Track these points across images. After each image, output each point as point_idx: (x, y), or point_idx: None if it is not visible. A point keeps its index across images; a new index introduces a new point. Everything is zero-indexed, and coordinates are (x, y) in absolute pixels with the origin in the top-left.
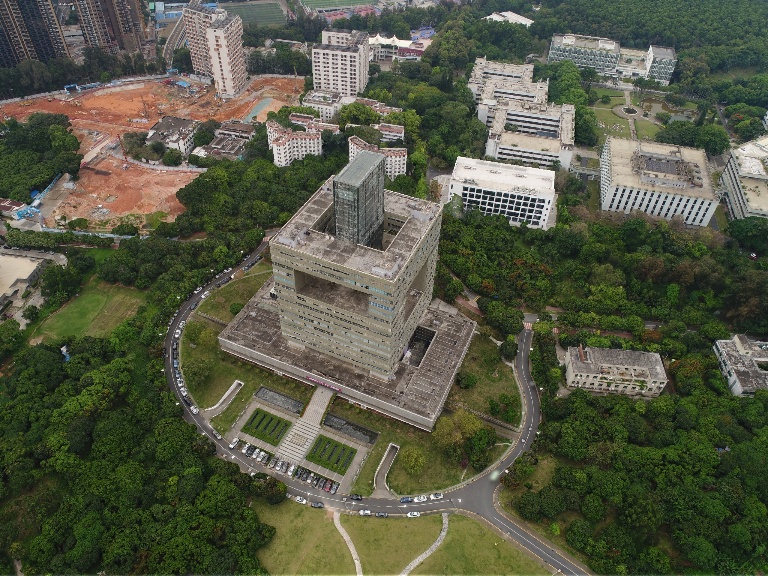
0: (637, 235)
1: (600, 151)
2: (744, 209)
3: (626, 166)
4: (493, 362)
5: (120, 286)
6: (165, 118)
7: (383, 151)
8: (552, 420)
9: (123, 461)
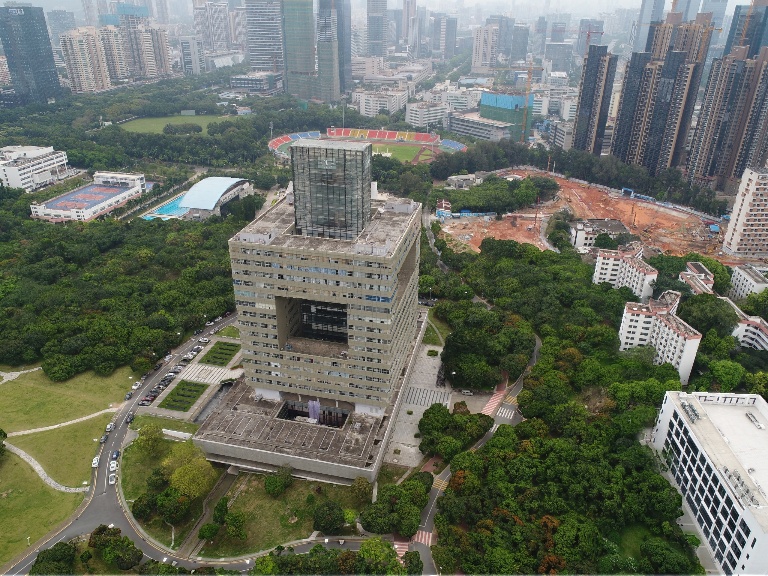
0: None
1: None
2: None
3: None
4: None
5: None
6: (615, 221)
7: (671, 318)
8: None
9: (191, 297)
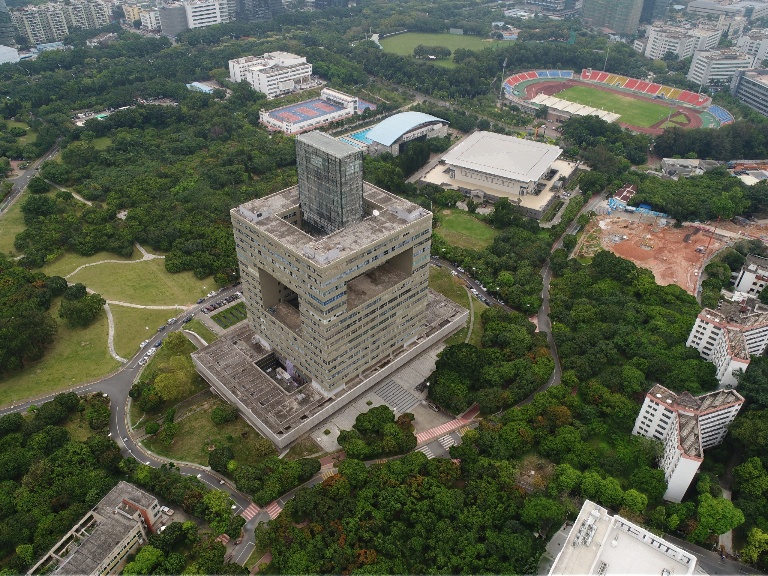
0: None
1: None
2: None
3: None
4: None
5: None
6: None
7: (691, 424)
8: None
9: None
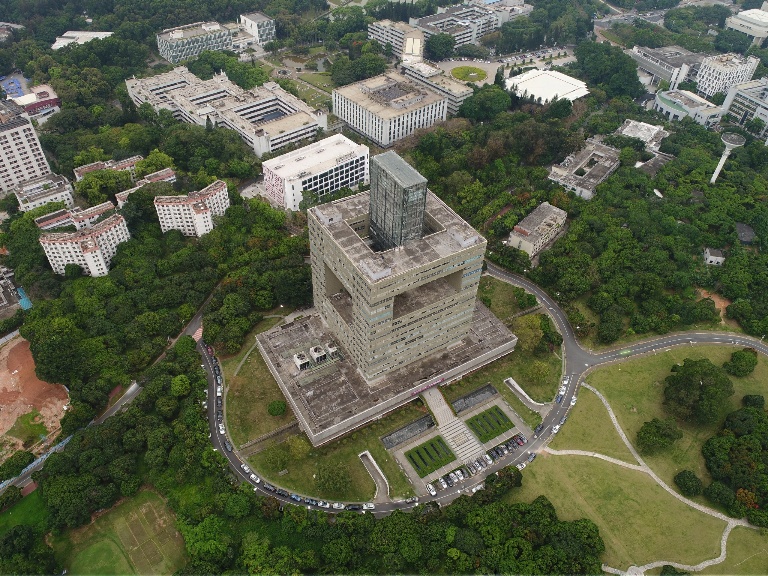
0: (436, 145)
1: (327, 107)
2: (452, 97)
3: (373, 105)
4: None
5: (100, 516)
6: None
7: (203, 194)
8: (548, 284)
9: None
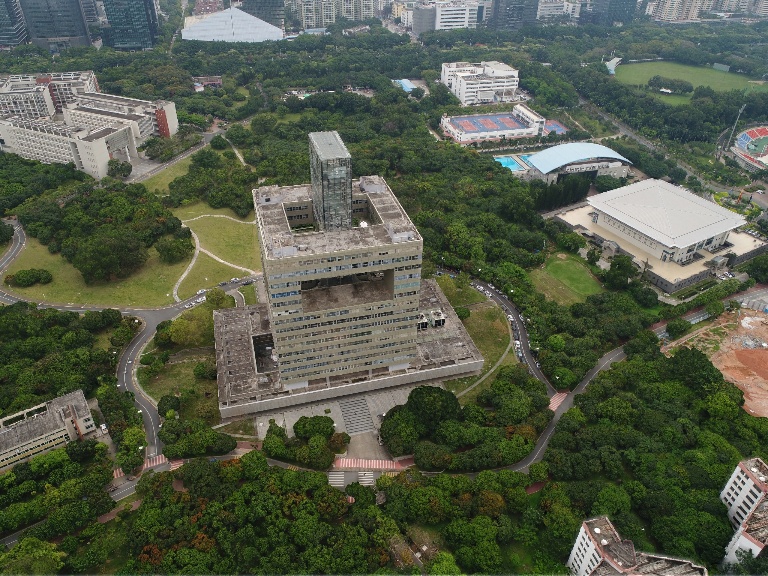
0: None
1: None
2: None
3: None
4: (186, 405)
5: None
6: None
7: None
8: None
9: None
